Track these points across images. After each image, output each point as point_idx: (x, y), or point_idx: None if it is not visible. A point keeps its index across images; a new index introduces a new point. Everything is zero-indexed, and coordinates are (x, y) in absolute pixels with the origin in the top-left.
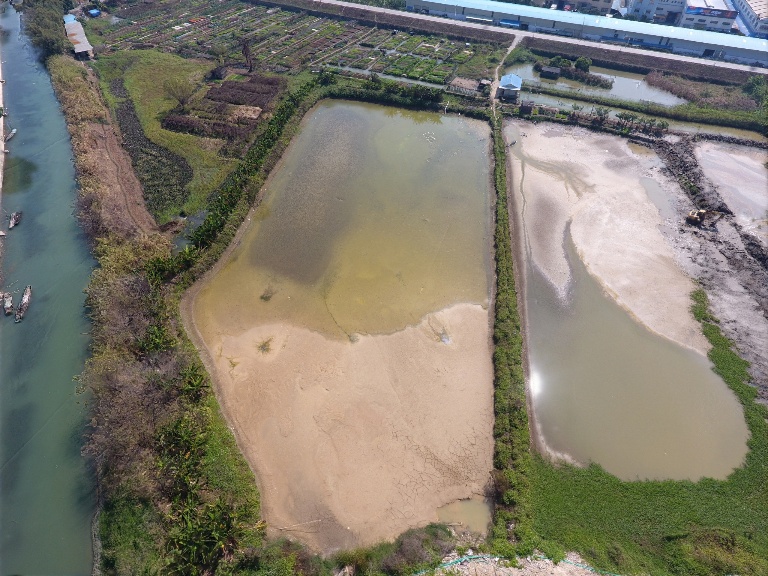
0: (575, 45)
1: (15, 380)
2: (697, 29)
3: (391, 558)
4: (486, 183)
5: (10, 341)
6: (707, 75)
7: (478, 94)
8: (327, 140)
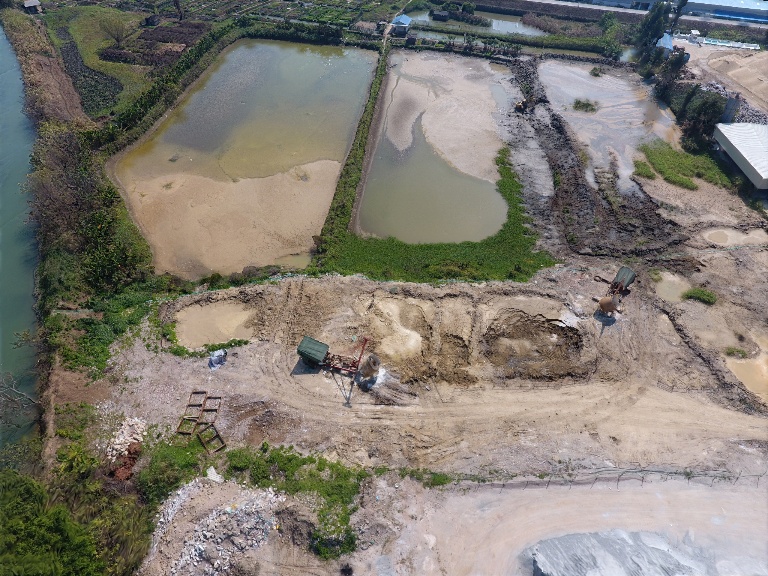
0: None
1: None
2: None
3: (233, 273)
4: (364, 90)
5: None
6: (572, 14)
7: (374, 32)
8: (240, 66)
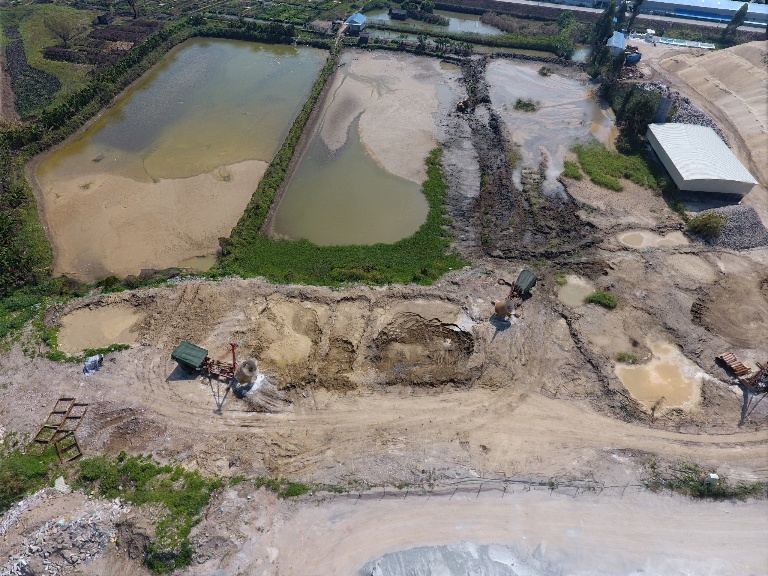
0: None
1: None
2: None
3: (129, 276)
4: (307, 90)
5: None
6: (532, 13)
7: (329, 31)
8: (186, 65)
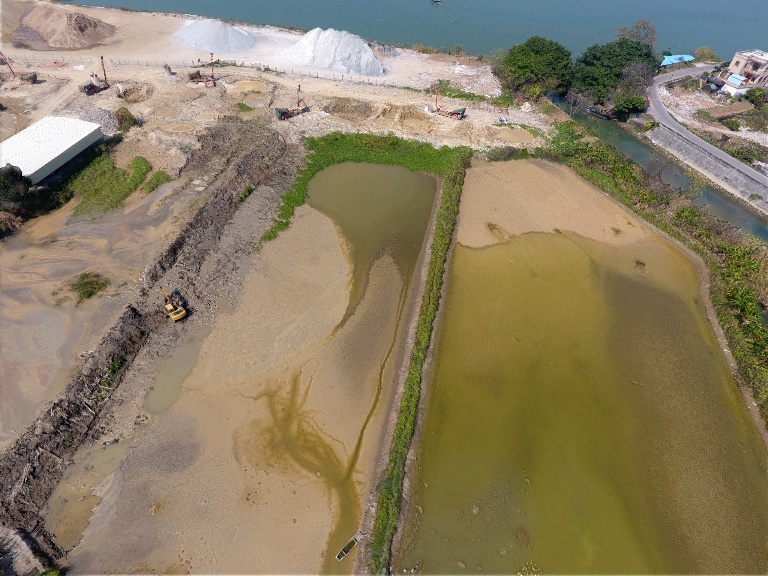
0: None
1: None
2: None
3: (514, 148)
4: (431, 409)
5: None
6: None
7: None
8: None
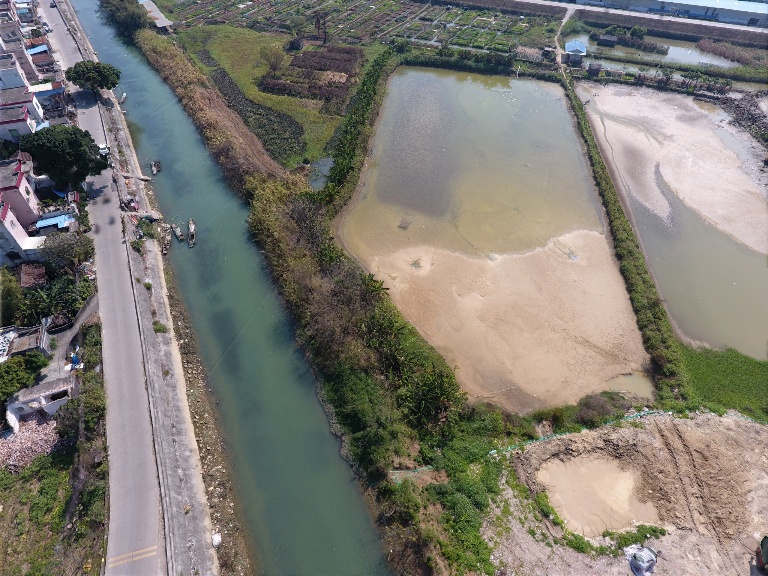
0: (626, 16)
1: (207, 291)
2: (739, 0)
3: (584, 411)
4: (573, 134)
5: (190, 262)
6: (756, 41)
7: (545, 60)
8: (415, 100)
